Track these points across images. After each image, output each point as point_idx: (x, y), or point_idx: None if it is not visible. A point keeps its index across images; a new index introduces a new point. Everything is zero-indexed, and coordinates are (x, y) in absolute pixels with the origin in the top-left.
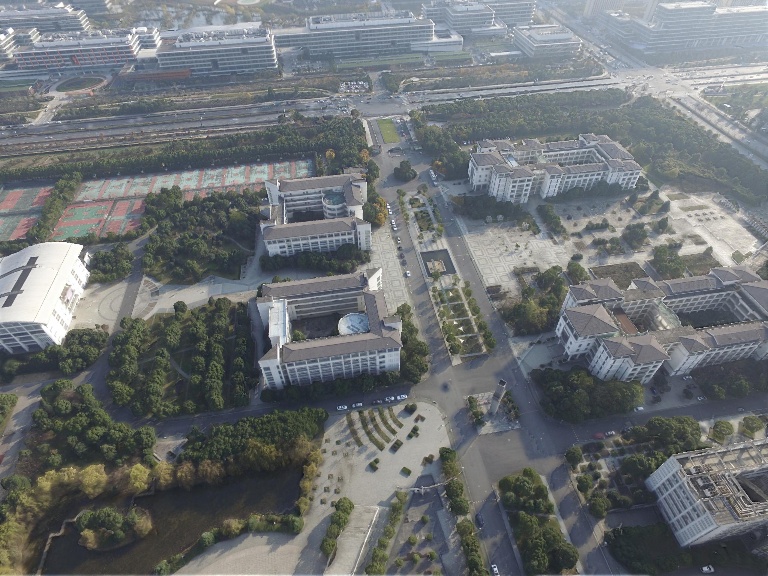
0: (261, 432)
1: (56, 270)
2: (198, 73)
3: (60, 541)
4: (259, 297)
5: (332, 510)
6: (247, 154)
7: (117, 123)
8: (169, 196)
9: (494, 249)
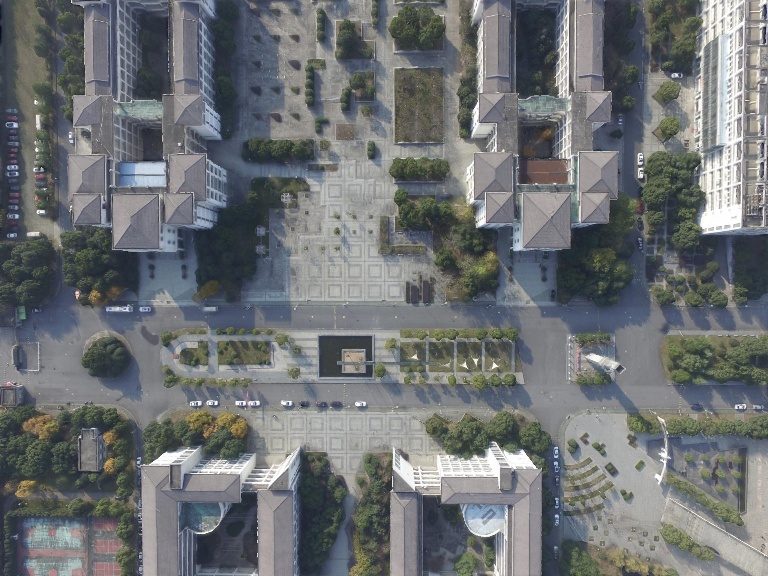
0: None
1: None
2: None
3: None
4: None
5: (662, 541)
6: None
7: None
8: None
9: (331, 266)
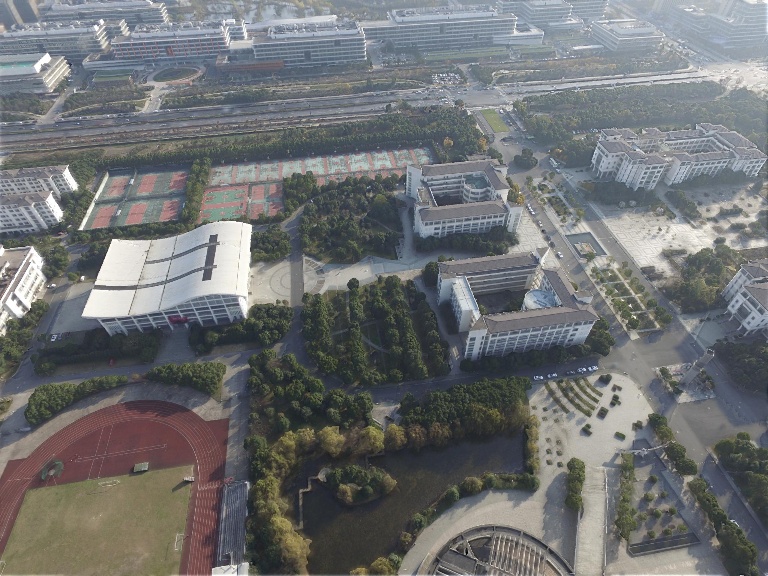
0: (480, 397)
1: (238, 247)
2: (290, 64)
3: (310, 496)
4: (442, 273)
5: (561, 470)
6: (367, 142)
7: (225, 112)
8: (306, 181)
9: (636, 232)
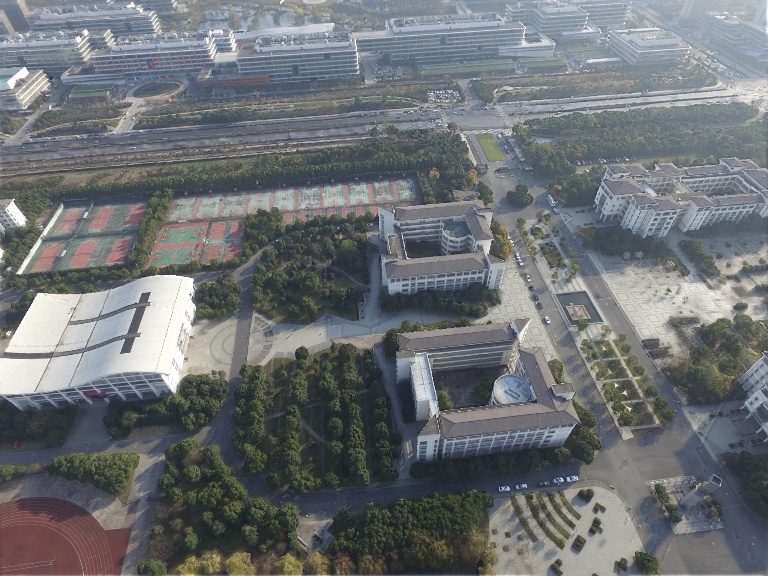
0: (426, 522)
1: (171, 309)
2: (277, 79)
3: None
4: None
5: None
6: (344, 172)
7: (200, 133)
8: (270, 219)
9: (640, 293)
